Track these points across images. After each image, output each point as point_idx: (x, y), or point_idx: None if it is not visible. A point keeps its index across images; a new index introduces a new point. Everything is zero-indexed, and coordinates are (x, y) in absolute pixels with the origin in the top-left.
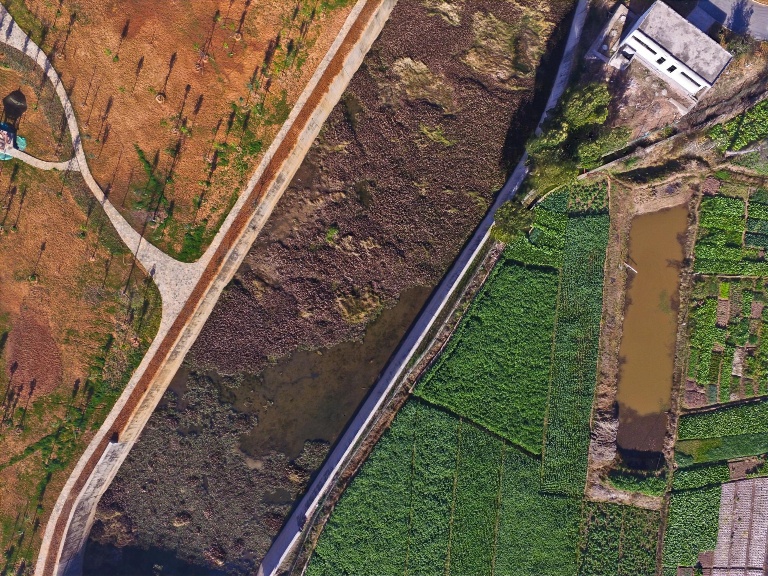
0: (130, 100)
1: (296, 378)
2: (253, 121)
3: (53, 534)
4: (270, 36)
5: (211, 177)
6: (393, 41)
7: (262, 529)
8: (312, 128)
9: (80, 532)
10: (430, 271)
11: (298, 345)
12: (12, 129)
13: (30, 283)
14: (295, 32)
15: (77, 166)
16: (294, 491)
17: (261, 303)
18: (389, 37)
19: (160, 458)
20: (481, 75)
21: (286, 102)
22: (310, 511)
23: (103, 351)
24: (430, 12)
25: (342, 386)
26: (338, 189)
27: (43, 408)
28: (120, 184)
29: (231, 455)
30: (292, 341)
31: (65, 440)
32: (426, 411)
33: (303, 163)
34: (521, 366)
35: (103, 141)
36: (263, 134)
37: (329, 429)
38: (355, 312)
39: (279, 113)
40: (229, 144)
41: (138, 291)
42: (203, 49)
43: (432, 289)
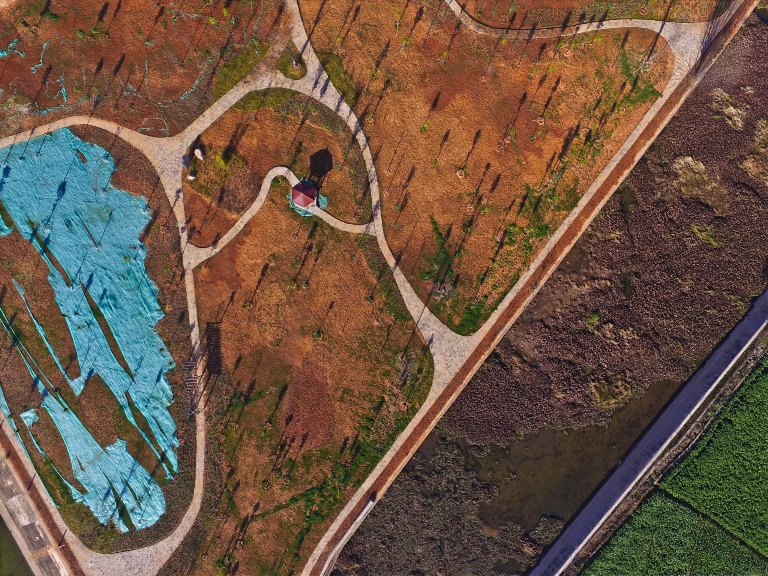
0: (432, 171)
1: (540, 454)
2: (543, 205)
3: None
4: (571, 124)
5: (497, 255)
6: (676, 138)
7: None
8: (593, 216)
9: None
10: (682, 367)
11: (547, 423)
12: (315, 186)
13: (314, 339)
14: (594, 122)
15: (373, 230)
16: (526, 563)
17: (517, 379)
18: (673, 134)
19: (402, 516)
20: (755, 182)
21: (576, 190)
22: None
23: (374, 412)
24: (716, 114)
25: (583, 467)
26: (604, 277)
27: (311, 461)
28: (412, 252)
29: (470, 521)
30: (543, 419)
31: (328, 494)
32: (670, 504)
33: (573, 247)
34: (766, 472)
35: (401, 209)
36: (551, 219)
37: (565, 507)
38: (606, 398)
39: (569, 200)
40: (518, 225)
41: (414, 358)
42: (506, 129)
43: (680, 384)
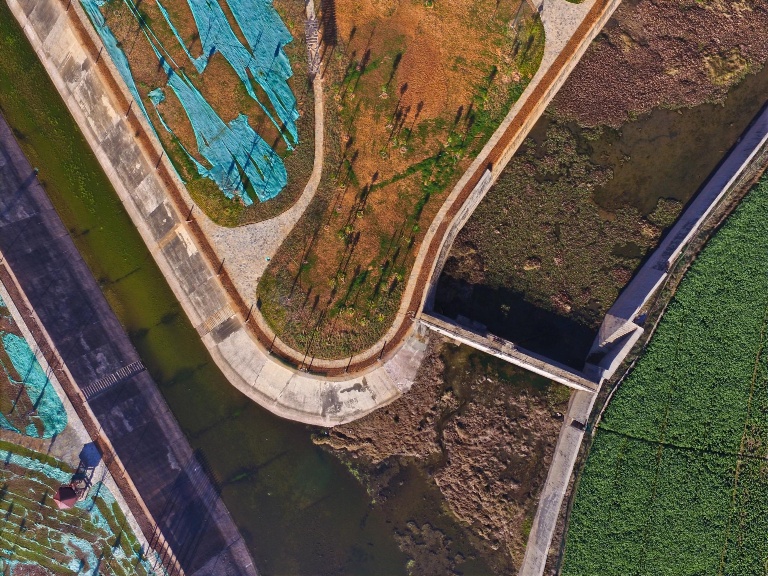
0: None
1: (654, 136)
2: None
3: (427, 253)
4: None
5: None
6: None
7: (610, 280)
8: None
9: (441, 261)
10: None
11: (659, 103)
12: None
13: (426, 8)
14: None
15: None
16: (645, 246)
17: (627, 58)
18: None
19: (515, 202)
20: None
21: None
22: (673, 257)
23: (486, 82)
24: None
25: (699, 147)
26: None
27: (427, 131)
28: None
29: (585, 205)
30: (656, 97)
31: (444, 164)
32: None
33: None
34: None
35: None
36: None
37: (683, 189)
38: (721, 73)
39: None
40: None
41: (525, 26)
42: None
43: None
